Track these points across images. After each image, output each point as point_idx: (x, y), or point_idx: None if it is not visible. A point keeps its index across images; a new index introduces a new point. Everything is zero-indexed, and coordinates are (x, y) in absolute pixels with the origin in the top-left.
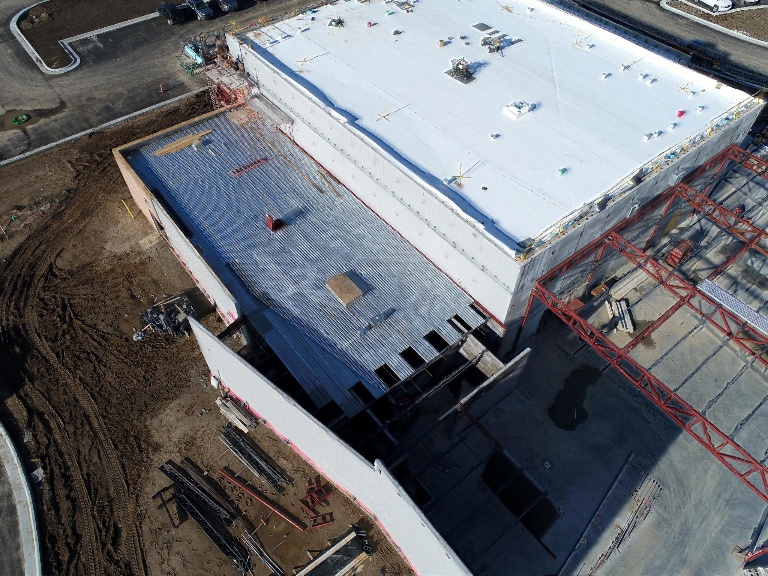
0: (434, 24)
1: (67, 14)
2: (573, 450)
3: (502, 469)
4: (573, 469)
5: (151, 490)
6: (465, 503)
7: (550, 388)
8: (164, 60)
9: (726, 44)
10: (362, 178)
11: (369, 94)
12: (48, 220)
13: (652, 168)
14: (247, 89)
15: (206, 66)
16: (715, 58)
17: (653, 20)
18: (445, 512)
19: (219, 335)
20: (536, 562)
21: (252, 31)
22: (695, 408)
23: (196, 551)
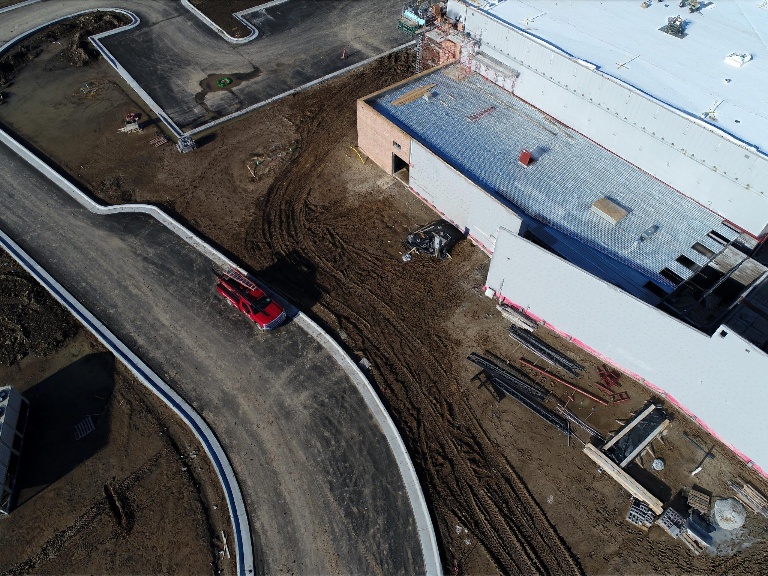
0: None
1: None
2: None
3: None
4: None
5: (466, 375)
6: None
7: None
8: (334, 31)
9: None
10: (603, 119)
11: (599, 47)
12: (288, 165)
13: None
14: (472, 47)
15: (426, 28)
16: None
17: None
18: None
19: None
20: None
21: None
22: None
23: (522, 419)
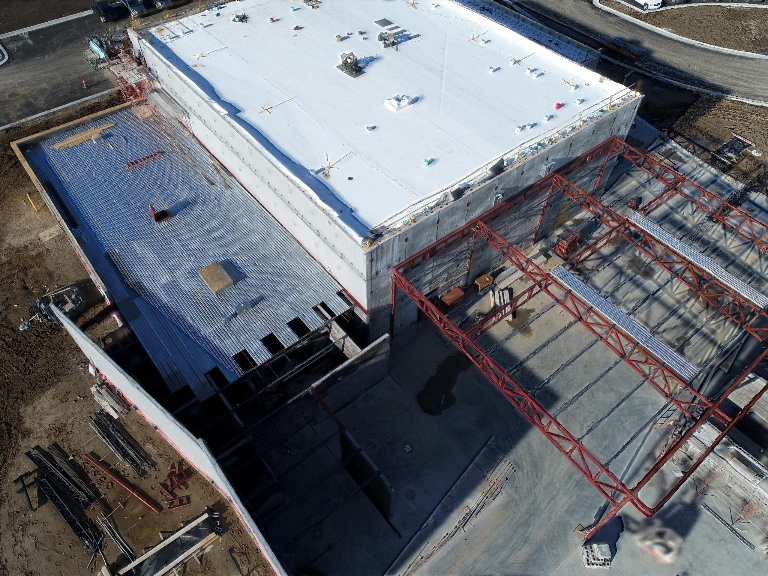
0: (337, 20)
1: (1, 11)
2: (435, 434)
3: (350, 451)
4: (432, 452)
5: (15, 475)
6: (321, 485)
7: (422, 374)
8: None
9: (651, 41)
10: (245, 170)
11: (257, 88)
12: None
13: (517, 158)
14: (146, 83)
15: (110, 61)
16: (638, 55)
17: (583, 18)
18: (300, 494)
19: (86, 322)
20: (381, 541)
21: (155, 26)
22: (561, 393)
23: (50, 533)
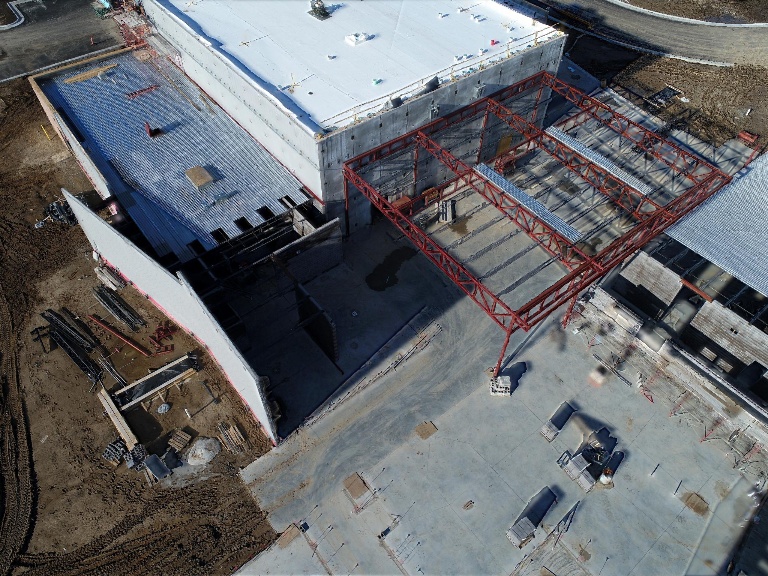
0: None
1: None
2: (378, 304)
3: (303, 304)
4: (374, 316)
5: (31, 329)
6: (281, 338)
7: (372, 262)
8: (99, 19)
9: (606, 10)
10: (226, 94)
11: (238, 27)
12: None
13: None
14: (145, 28)
15: (114, 11)
16: (592, 21)
17: None
18: (263, 344)
19: (91, 209)
20: (327, 376)
21: None
22: None
23: (60, 368)
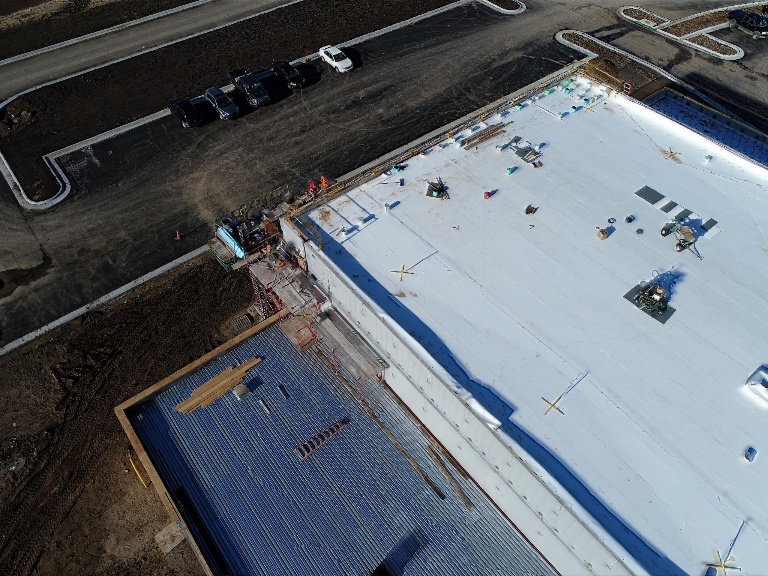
0: (579, 191)
1: (54, 113)
2: None
3: None
4: None
5: None
6: None
7: None
8: (179, 184)
9: None
10: (519, 504)
11: (517, 347)
12: (21, 490)
13: None
14: (314, 306)
15: (250, 259)
16: None
17: None
18: None
19: None
20: None
21: (317, 208)
22: None
23: None
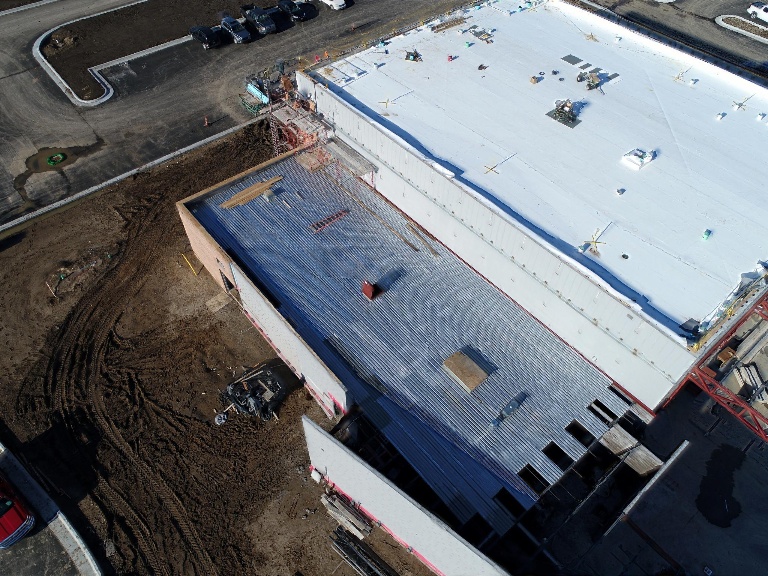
0: (520, 57)
1: (93, 38)
2: (733, 551)
3: None
4: (738, 575)
5: None
6: None
7: (692, 474)
8: (204, 89)
9: None
10: (469, 238)
11: (468, 141)
12: (101, 279)
13: None
14: (323, 132)
15: (273, 106)
16: None
17: (712, 39)
18: None
19: (332, 431)
20: None
21: (323, 67)
22: None
23: None
